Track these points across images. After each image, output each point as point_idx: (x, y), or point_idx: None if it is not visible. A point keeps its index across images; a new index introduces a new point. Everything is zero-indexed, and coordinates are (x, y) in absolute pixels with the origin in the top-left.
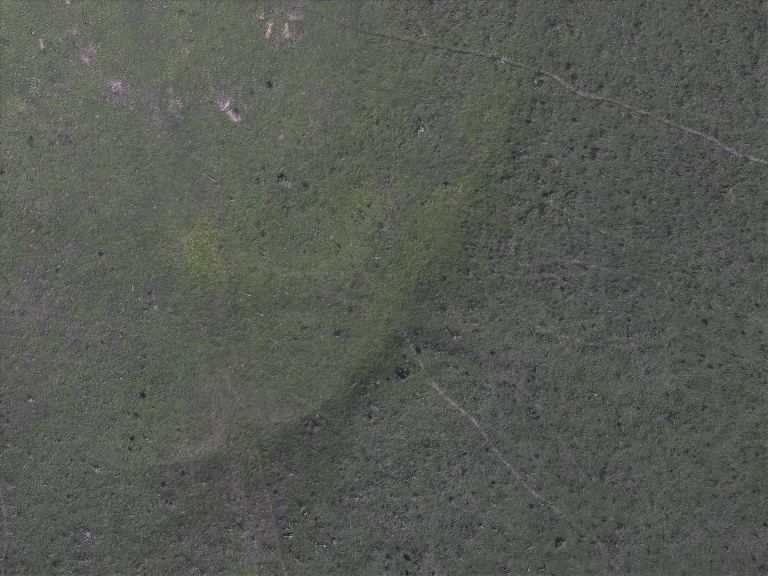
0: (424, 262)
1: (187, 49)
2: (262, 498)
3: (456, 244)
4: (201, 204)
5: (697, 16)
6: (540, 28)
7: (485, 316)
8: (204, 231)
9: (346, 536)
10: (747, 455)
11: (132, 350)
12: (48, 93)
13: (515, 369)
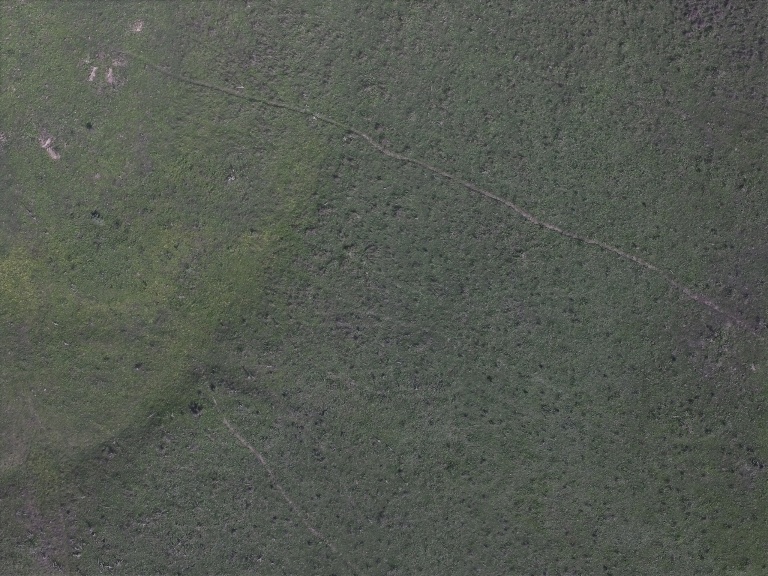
0: (226, 304)
1: (14, 86)
2: (56, 517)
3: (258, 288)
4: (17, 234)
5: (504, 86)
6: (353, 88)
7: (280, 359)
8: (18, 260)
9: (131, 559)
10: (520, 509)
11: None
12: None
13: (304, 412)
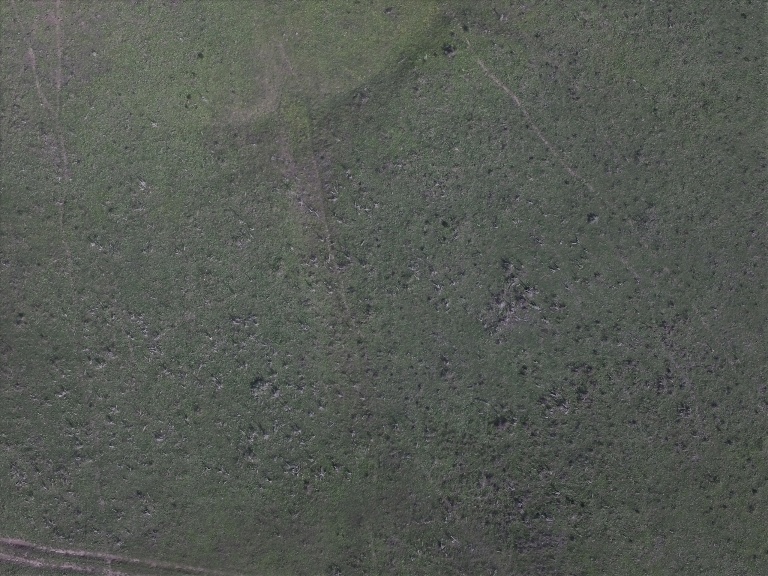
0: None
1: None
2: (309, 164)
3: None
4: None
5: None
6: None
7: (531, 0)
8: None
9: (388, 201)
10: None
11: (192, 13)
12: None
13: (558, 52)
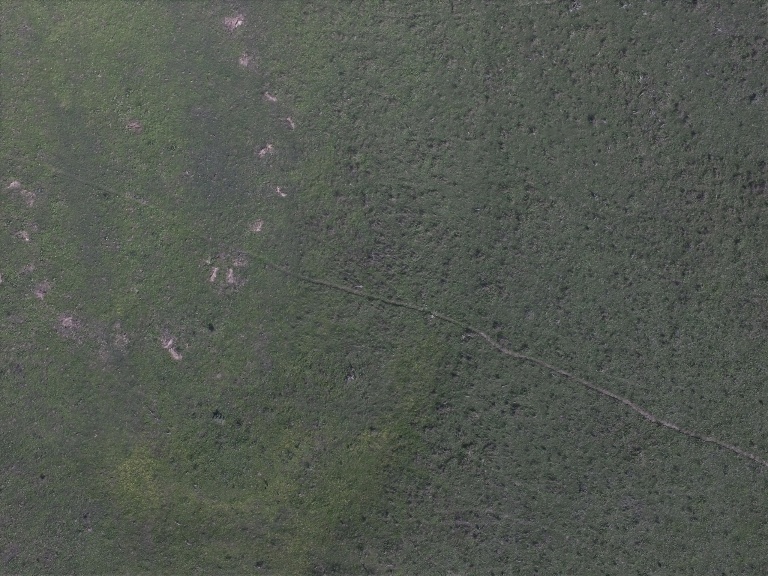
0: (346, 502)
1: (136, 288)
2: None
3: (377, 487)
4: (139, 434)
5: (621, 284)
6: (471, 286)
7: (400, 558)
8: (141, 460)
9: None
10: None
11: (65, 569)
12: (3, 323)
13: None
